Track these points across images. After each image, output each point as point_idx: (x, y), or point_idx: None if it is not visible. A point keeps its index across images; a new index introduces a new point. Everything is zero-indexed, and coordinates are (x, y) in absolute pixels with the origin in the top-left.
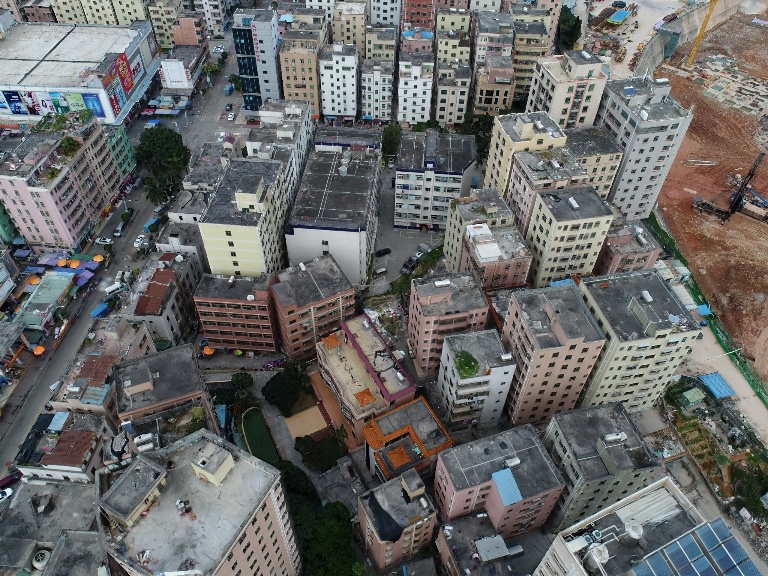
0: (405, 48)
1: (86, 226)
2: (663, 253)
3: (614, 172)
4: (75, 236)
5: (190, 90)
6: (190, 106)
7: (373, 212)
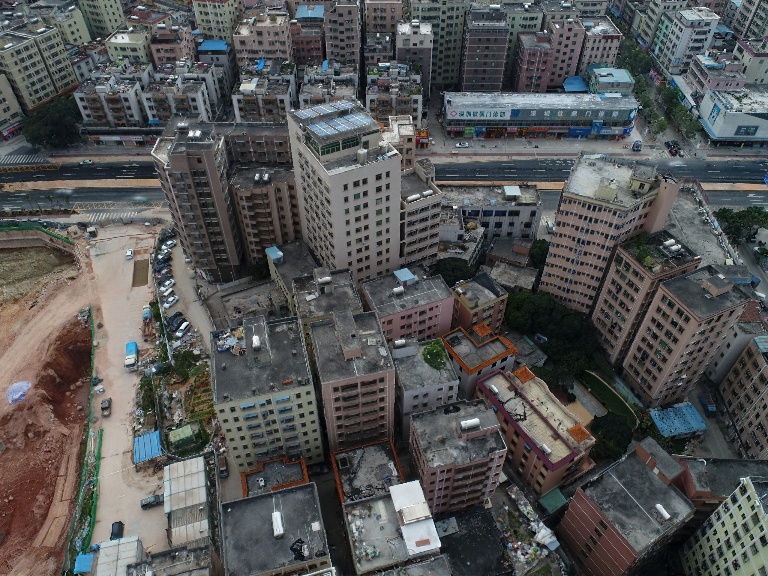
0: None
1: None
2: None
3: None
4: None
5: None
6: None
7: None
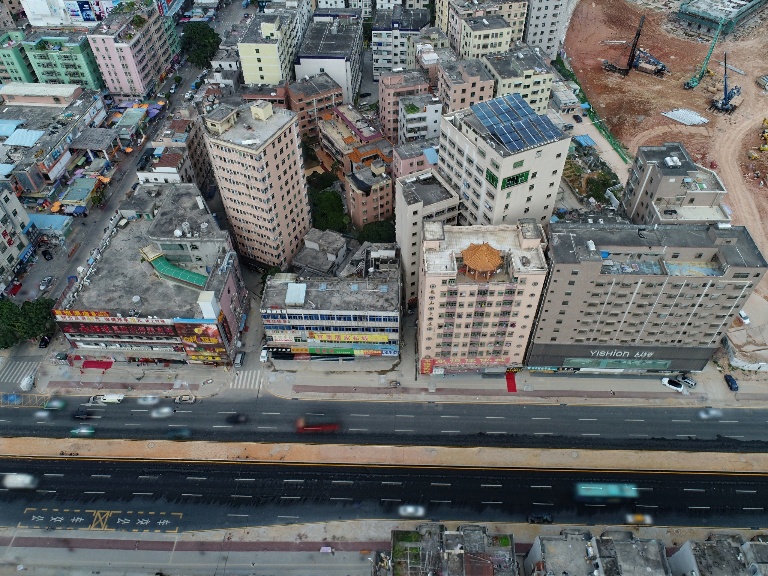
0: None
1: (151, 82)
2: None
3: (524, 18)
4: (144, 86)
5: (216, 3)
6: (216, 16)
7: (357, 62)
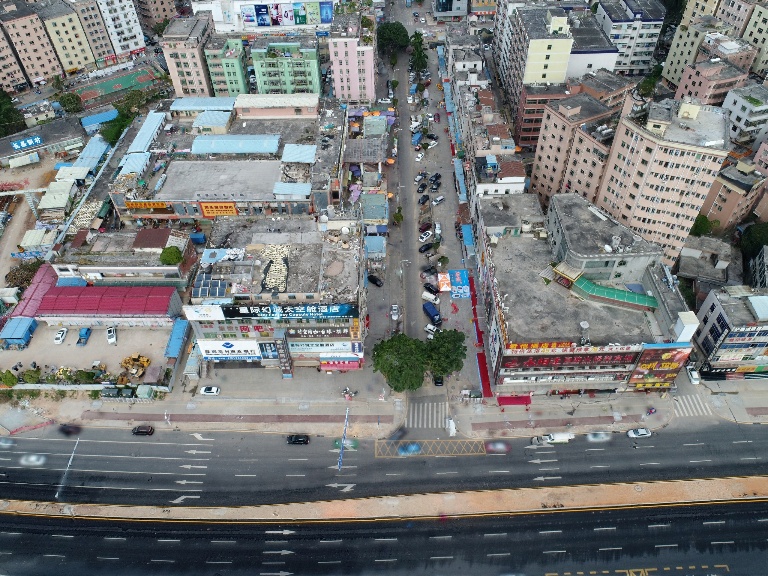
0: None
1: (375, 87)
2: None
3: None
4: None
5: (383, 3)
6: (383, 16)
7: None
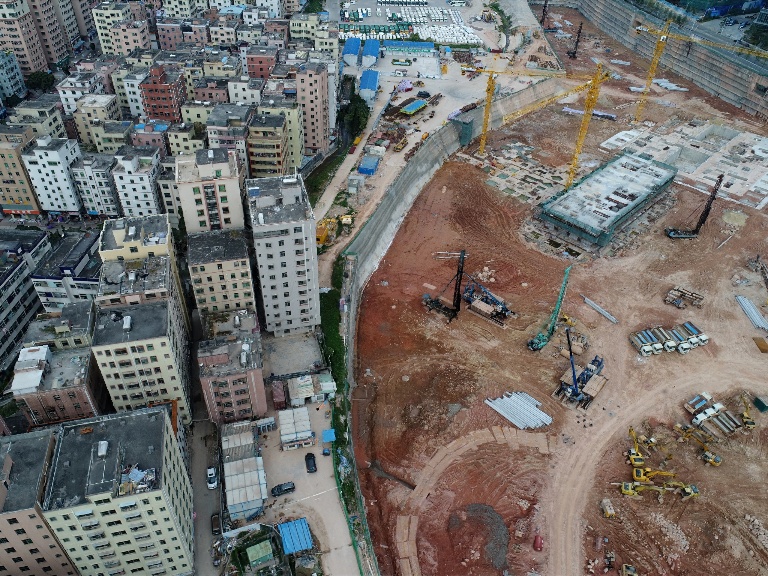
0: (135, 141)
1: None
2: (322, 365)
3: (249, 278)
4: None
5: None
6: None
7: (6, 324)
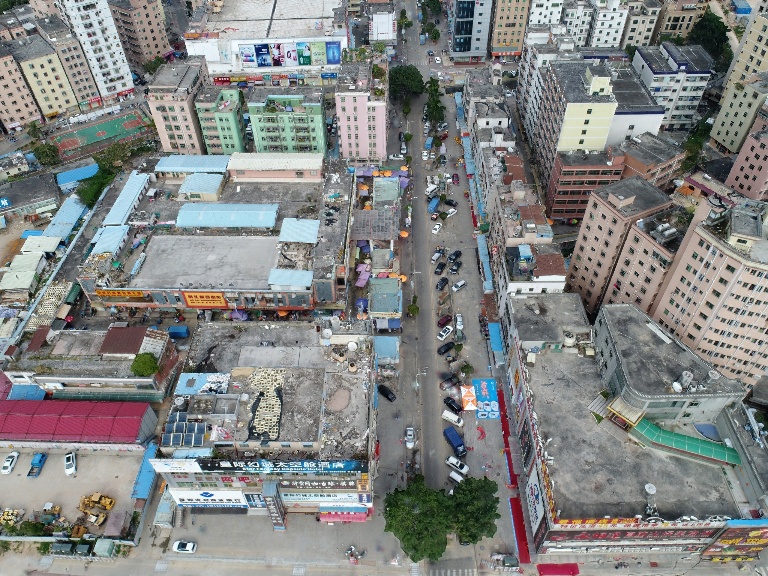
0: None
1: None
2: None
3: None
4: None
5: (395, 40)
6: (395, 55)
7: None
